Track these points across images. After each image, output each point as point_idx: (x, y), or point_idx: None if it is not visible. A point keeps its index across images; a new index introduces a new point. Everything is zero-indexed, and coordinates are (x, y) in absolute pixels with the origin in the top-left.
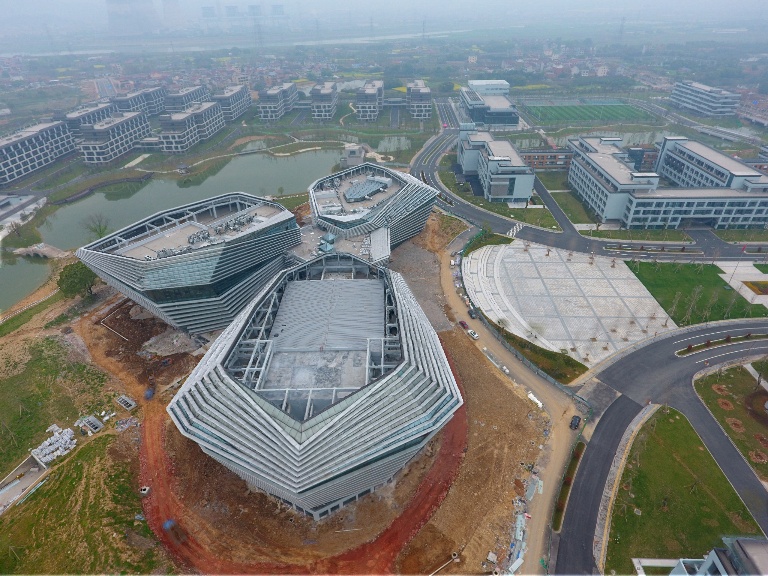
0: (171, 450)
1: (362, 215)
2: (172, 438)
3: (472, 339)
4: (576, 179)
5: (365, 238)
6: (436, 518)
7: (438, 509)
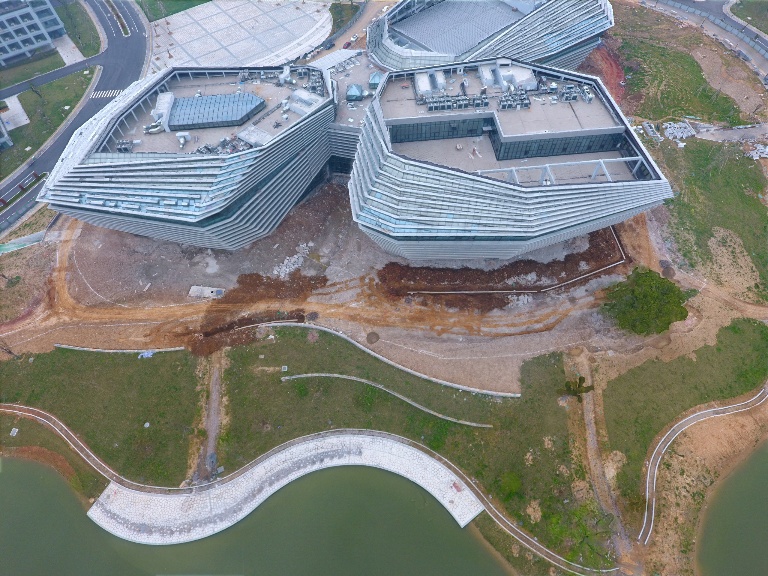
0: None
1: None
2: None
3: (358, 39)
4: None
5: None
6: None
7: None
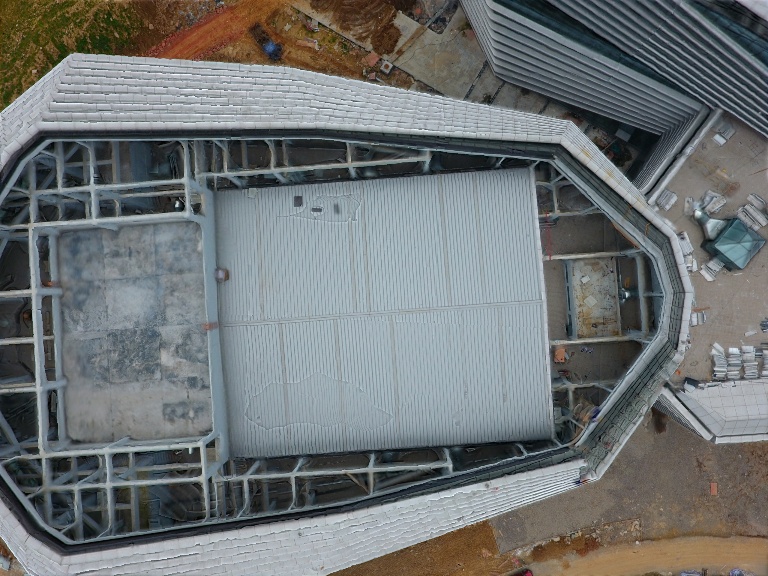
0: None
1: None
2: None
3: None
4: None
5: None
6: None
7: None
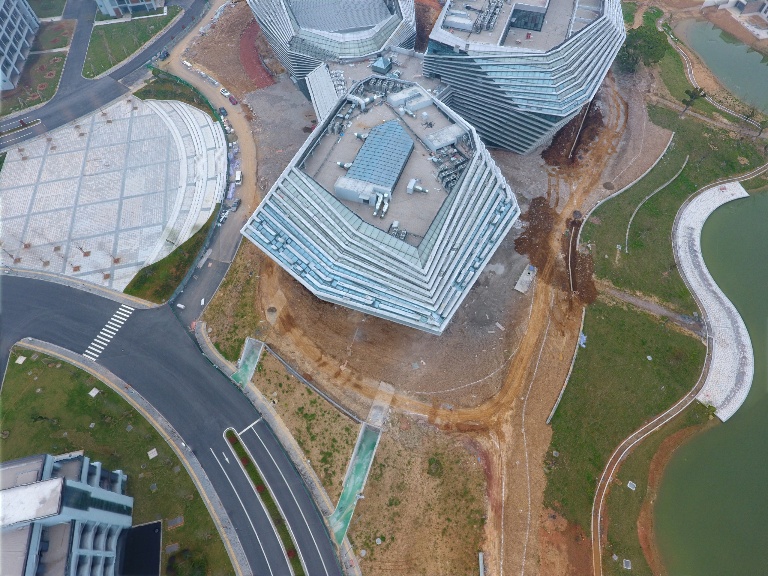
0: (417, 3)
1: None
2: (422, 6)
3: None
4: None
5: None
6: None
7: None
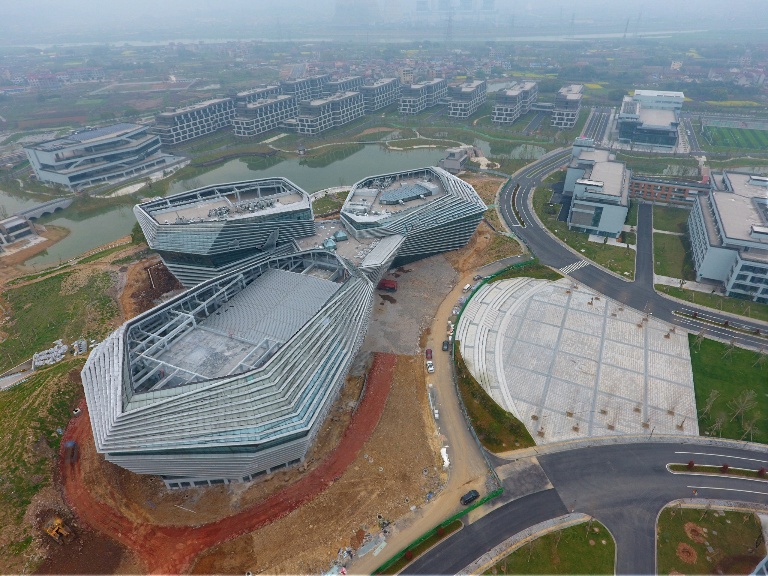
0: None
1: (378, 218)
2: None
3: (427, 371)
4: (693, 221)
5: (373, 242)
6: (260, 532)
7: (268, 525)
